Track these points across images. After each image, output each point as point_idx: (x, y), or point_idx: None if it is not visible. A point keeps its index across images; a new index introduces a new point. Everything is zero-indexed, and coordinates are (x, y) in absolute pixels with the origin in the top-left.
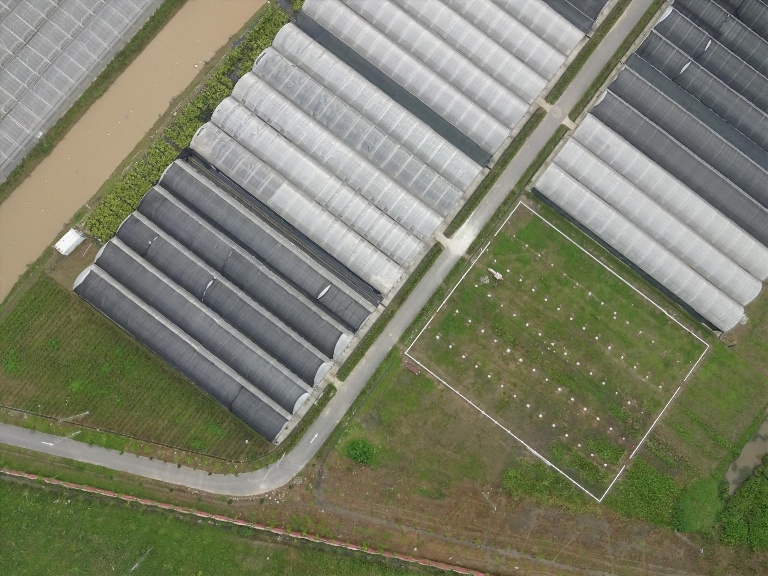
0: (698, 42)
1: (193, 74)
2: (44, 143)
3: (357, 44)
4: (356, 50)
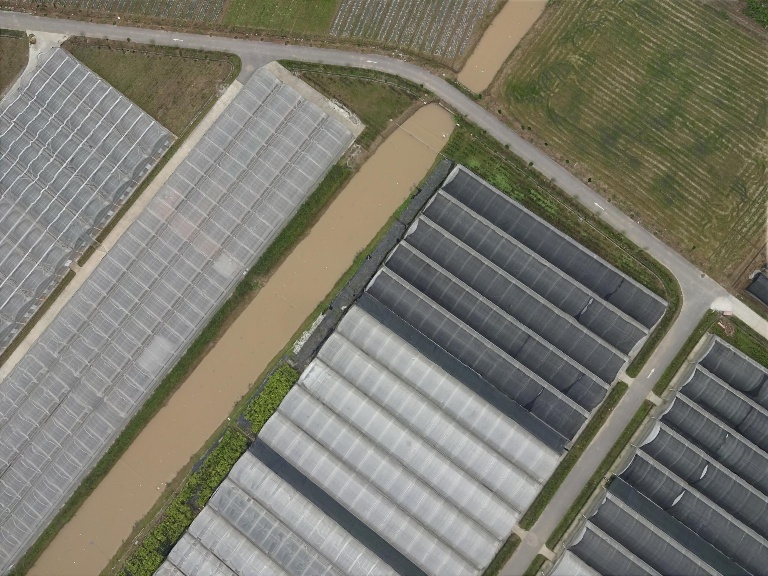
0: (692, 468)
1: (155, 497)
2: (15, 573)
3: (313, 476)
4: (313, 480)
